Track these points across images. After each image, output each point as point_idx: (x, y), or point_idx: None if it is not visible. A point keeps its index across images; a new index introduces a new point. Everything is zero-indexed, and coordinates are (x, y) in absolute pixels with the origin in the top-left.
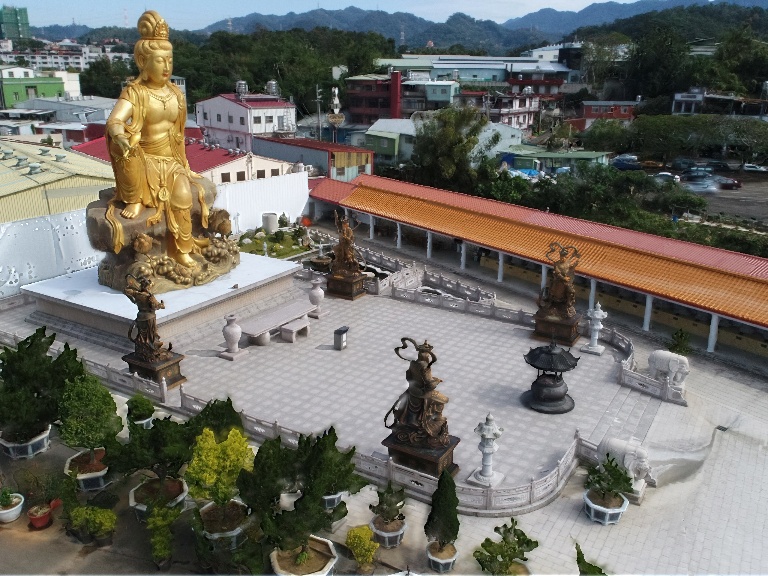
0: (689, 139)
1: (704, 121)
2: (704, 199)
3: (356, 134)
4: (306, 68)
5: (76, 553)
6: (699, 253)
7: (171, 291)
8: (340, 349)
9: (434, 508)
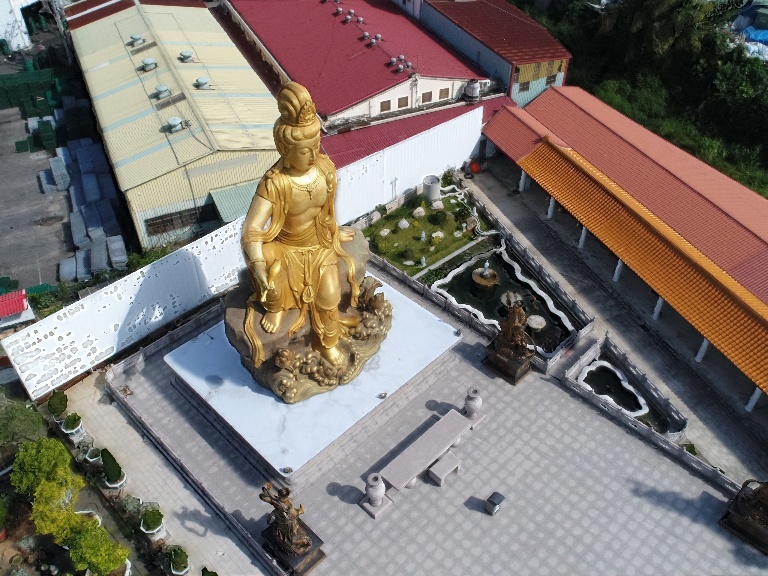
0: None
1: None
2: None
3: None
4: None
5: None
6: None
7: (314, 395)
8: (491, 514)
9: None
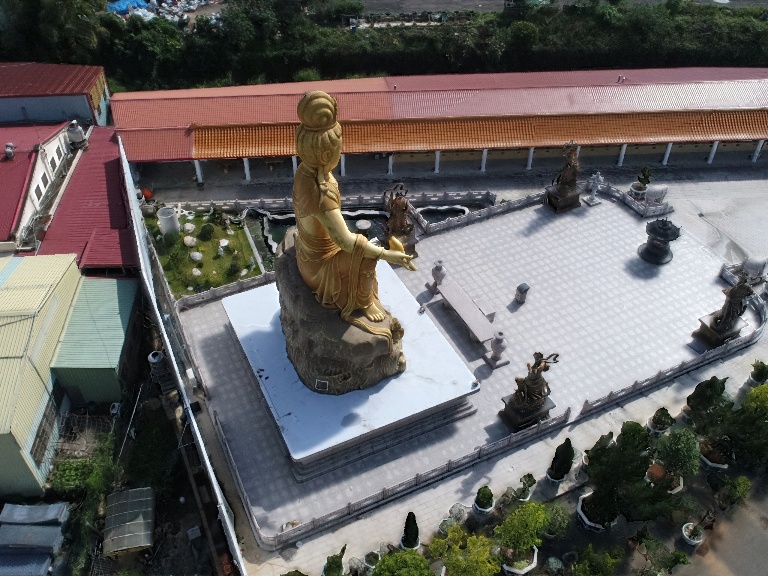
0: None
1: None
2: (361, 2)
3: None
4: None
5: (744, 509)
6: (551, 94)
7: None
8: (525, 302)
9: None
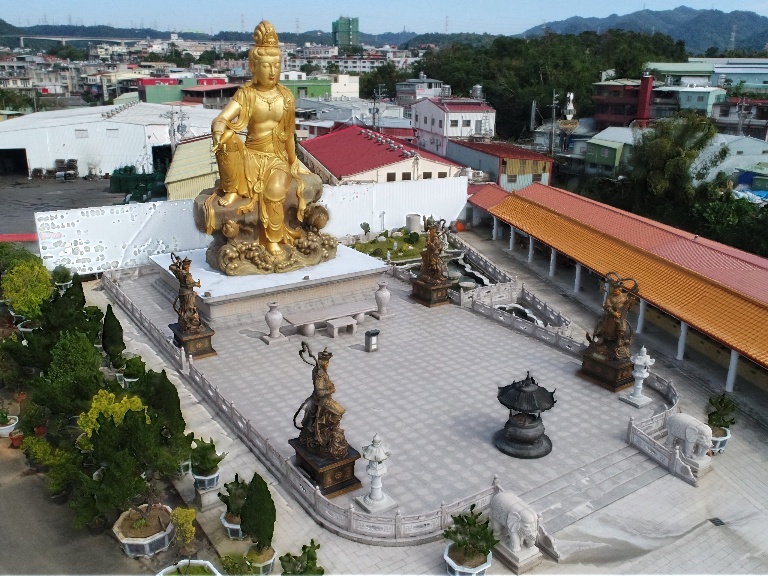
0: None
1: None
2: None
3: (579, 142)
4: (570, 72)
5: (20, 472)
6: None
7: (252, 275)
8: (369, 351)
9: (242, 508)
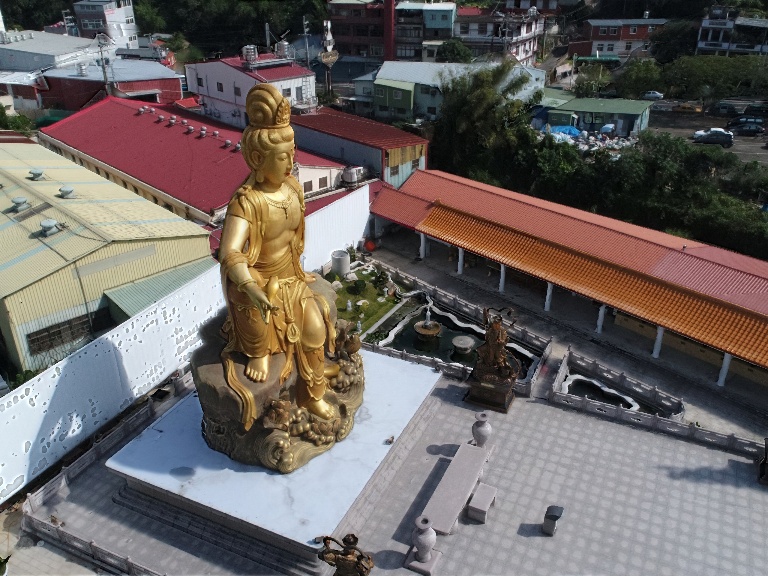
0: (738, 86)
1: (755, 65)
2: None
3: (361, 82)
4: None
5: None
6: None
7: (312, 458)
8: (551, 535)
9: None
